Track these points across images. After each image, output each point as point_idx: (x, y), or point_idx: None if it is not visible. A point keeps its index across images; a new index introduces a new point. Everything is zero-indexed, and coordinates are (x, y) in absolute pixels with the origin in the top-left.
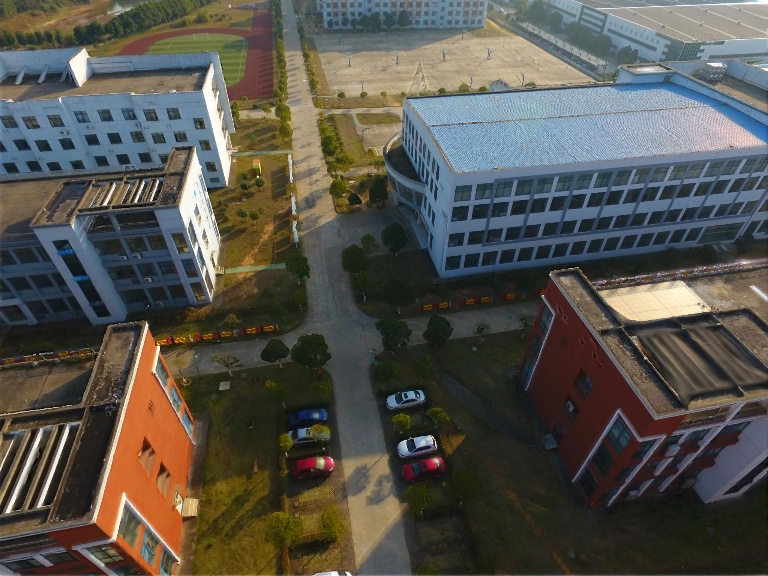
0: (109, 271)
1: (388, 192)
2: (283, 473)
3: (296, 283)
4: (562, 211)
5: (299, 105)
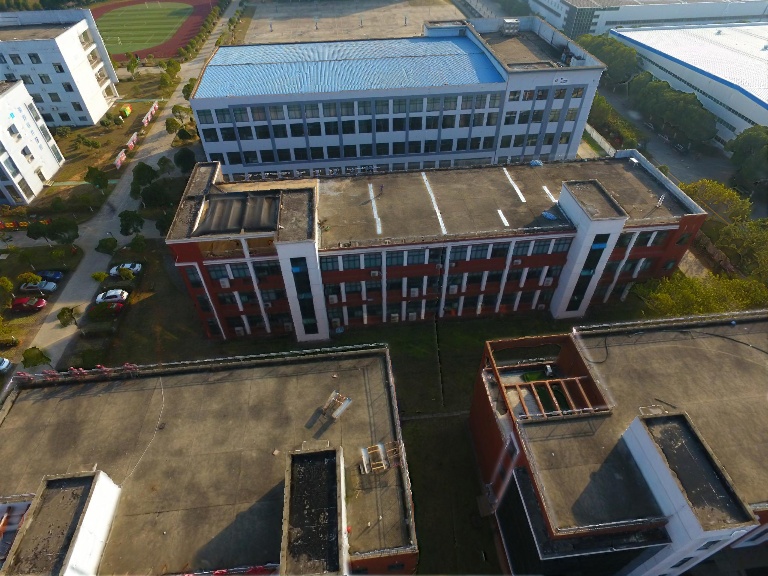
0: None
1: None
2: (4, 306)
3: (101, 194)
4: (304, 137)
5: (201, 63)
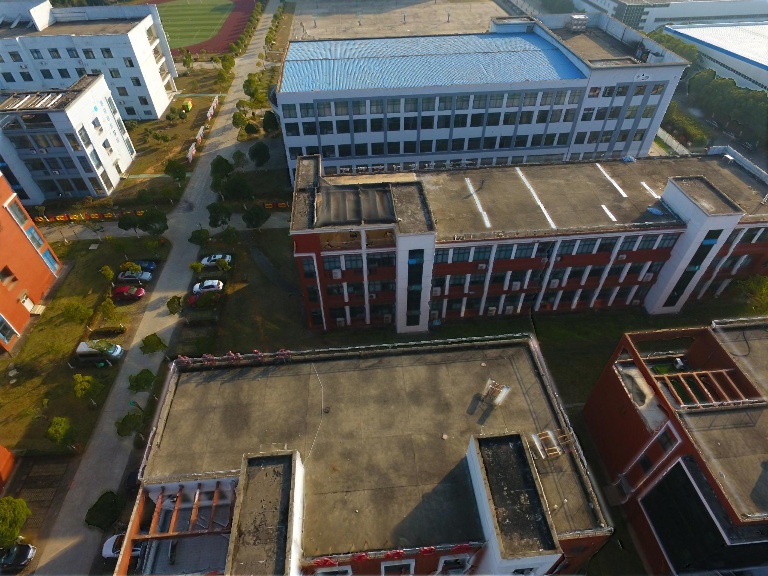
0: (26, 163)
1: (278, 124)
2: (106, 295)
3: (178, 186)
4: (383, 132)
5: (251, 59)
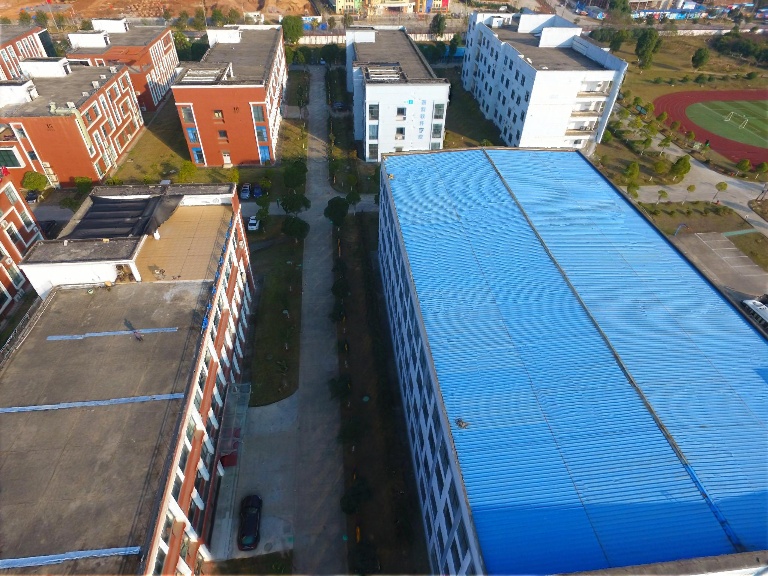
0: None
1: None
2: None
3: None
4: None
5: (744, 189)
